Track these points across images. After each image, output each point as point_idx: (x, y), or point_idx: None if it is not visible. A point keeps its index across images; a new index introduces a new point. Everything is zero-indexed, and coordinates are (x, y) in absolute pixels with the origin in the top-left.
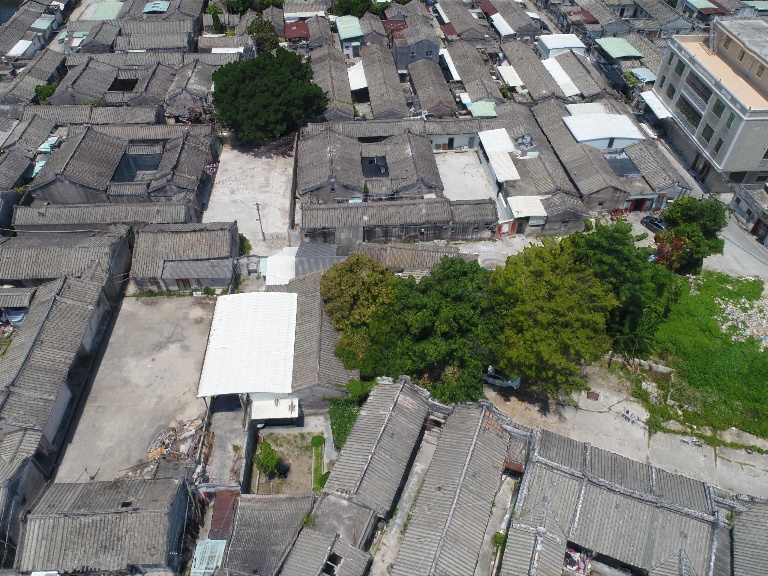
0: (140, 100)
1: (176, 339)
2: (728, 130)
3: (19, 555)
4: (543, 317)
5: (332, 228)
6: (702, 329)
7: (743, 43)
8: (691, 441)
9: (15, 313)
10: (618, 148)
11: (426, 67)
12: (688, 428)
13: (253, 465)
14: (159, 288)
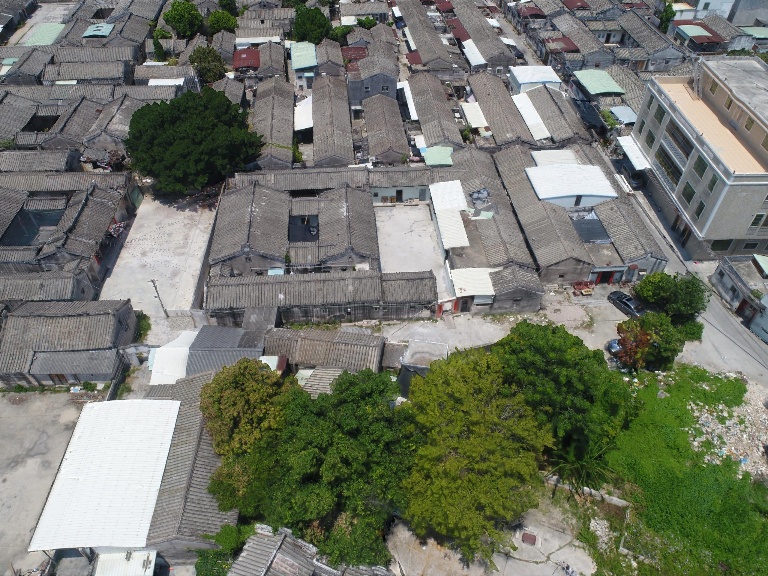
0: (55, 142)
1: (37, 452)
2: (710, 194)
3: None
4: (453, 466)
5: (241, 308)
6: (669, 446)
7: (730, 90)
8: None
9: None
10: (587, 206)
11: (381, 104)
12: None
13: None
14: (29, 383)
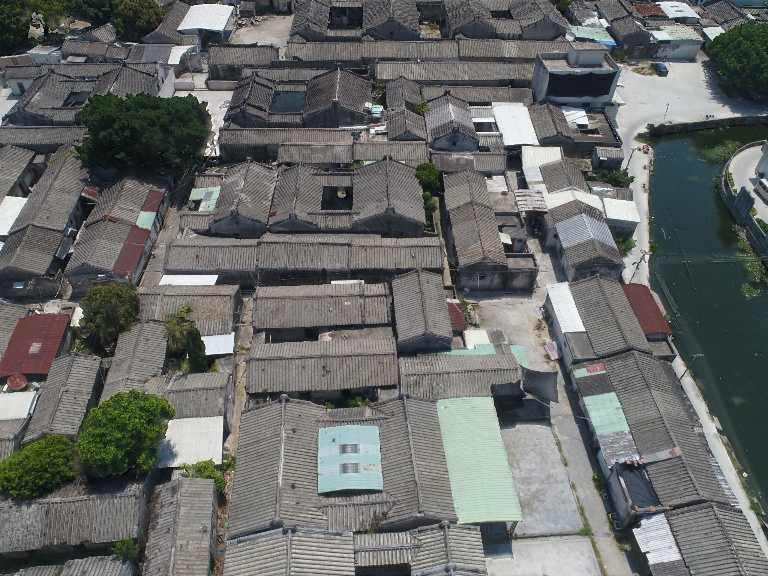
0: None
1: None
2: None
3: None
4: None
5: None
6: None
7: None
8: None
9: None
10: None
11: None
12: None
13: None
14: None
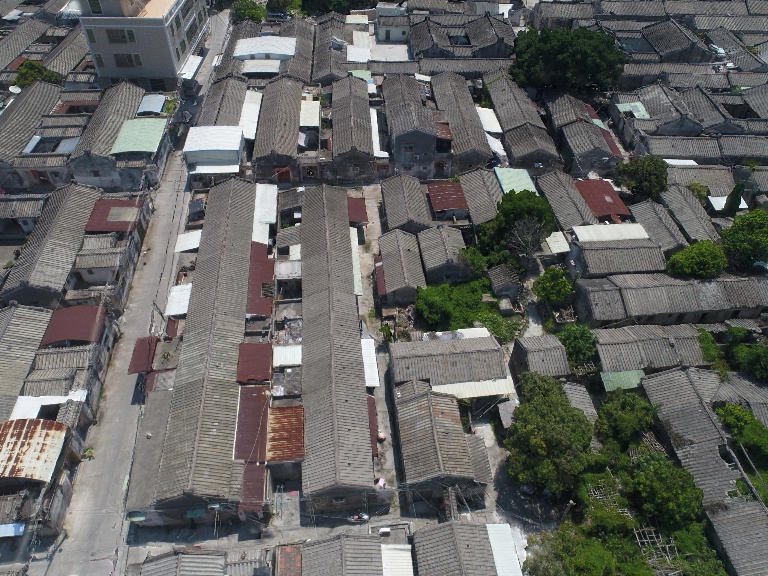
0: None
1: None
2: None
3: None
4: None
5: None
6: None
7: None
8: None
9: None
10: None
11: None
12: None
13: None
14: None
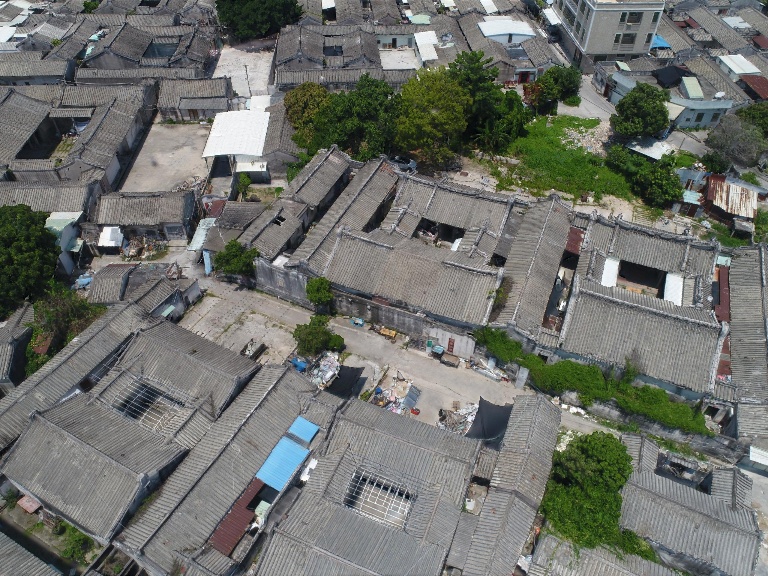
0: (162, 13)
1: (188, 144)
2: (587, 21)
3: (97, 215)
4: (419, 101)
5: (298, 84)
6: (548, 142)
7: None
8: (521, 192)
9: (81, 124)
10: (516, 43)
11: None
12: (523, 189)
13: (237, 199)
14: (177, 117)
